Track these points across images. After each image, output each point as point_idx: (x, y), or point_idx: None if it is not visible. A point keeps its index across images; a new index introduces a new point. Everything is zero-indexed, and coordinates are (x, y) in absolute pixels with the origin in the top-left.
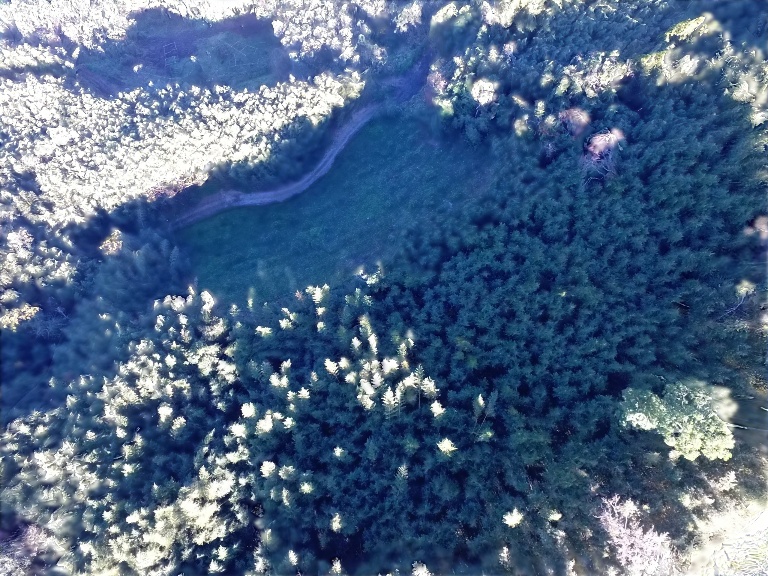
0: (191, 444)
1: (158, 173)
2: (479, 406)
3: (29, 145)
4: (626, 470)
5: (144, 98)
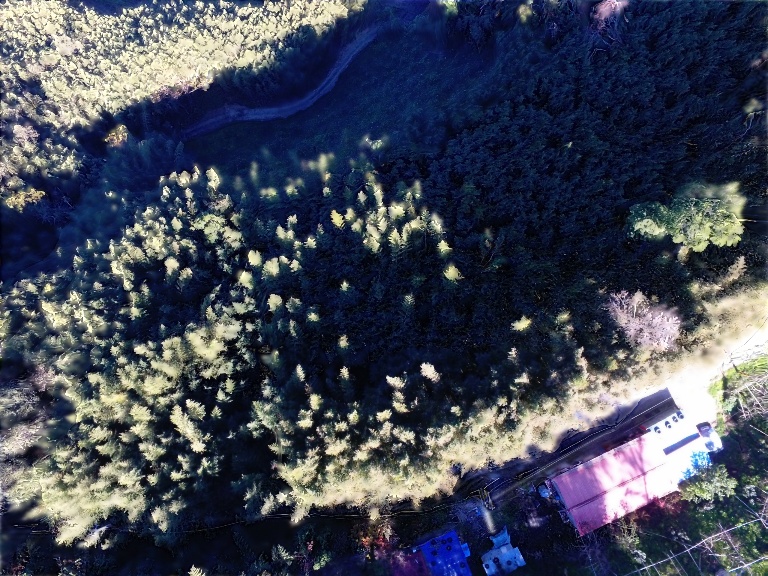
0: (198, 295)
1: (163, 76)
2: (486, 248)
3: (34, 55)
4: (634, 271)
5: (148, 13)
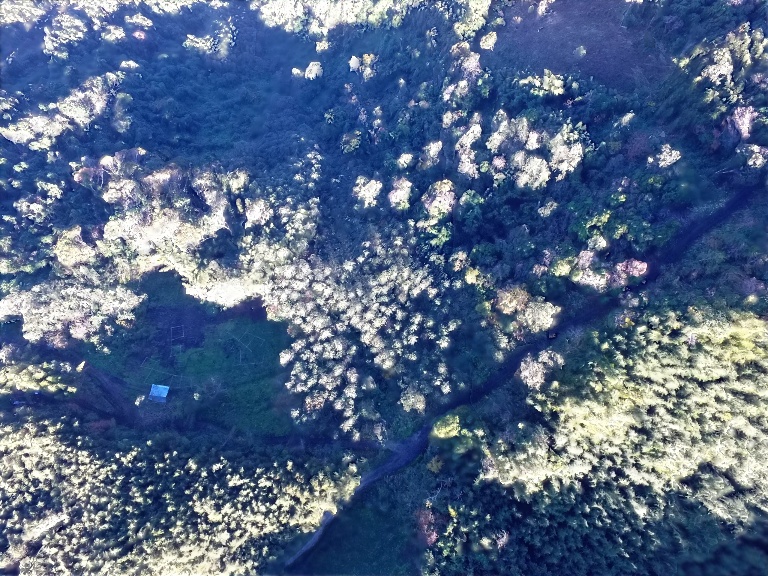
0: None
1: None
2: None
3: (17, 526)
4: None
5: (140, 467)
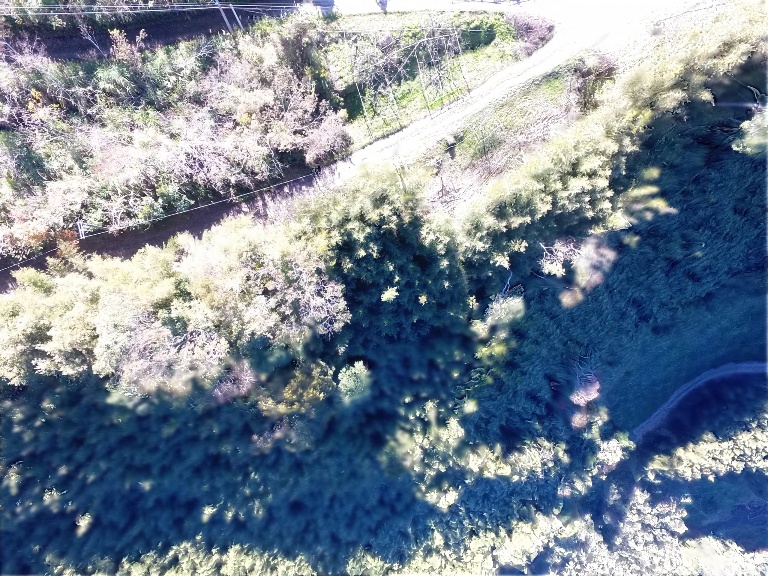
0: None
1: None
2: None
3: None
4: None
5: None
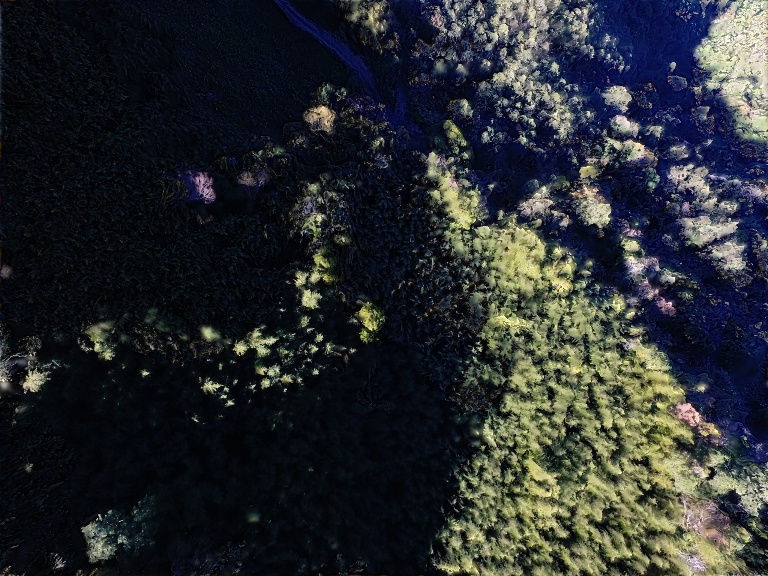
0: None
1: None
2: None
3: None
4: None
5: None
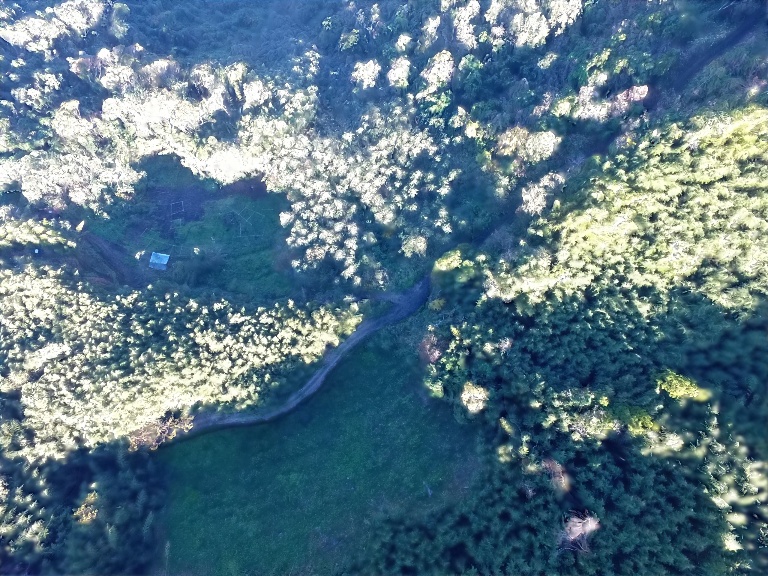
0: None
1: (143, 416)
2: None
3: (19, 356)
4: None
5: (141, 307)
